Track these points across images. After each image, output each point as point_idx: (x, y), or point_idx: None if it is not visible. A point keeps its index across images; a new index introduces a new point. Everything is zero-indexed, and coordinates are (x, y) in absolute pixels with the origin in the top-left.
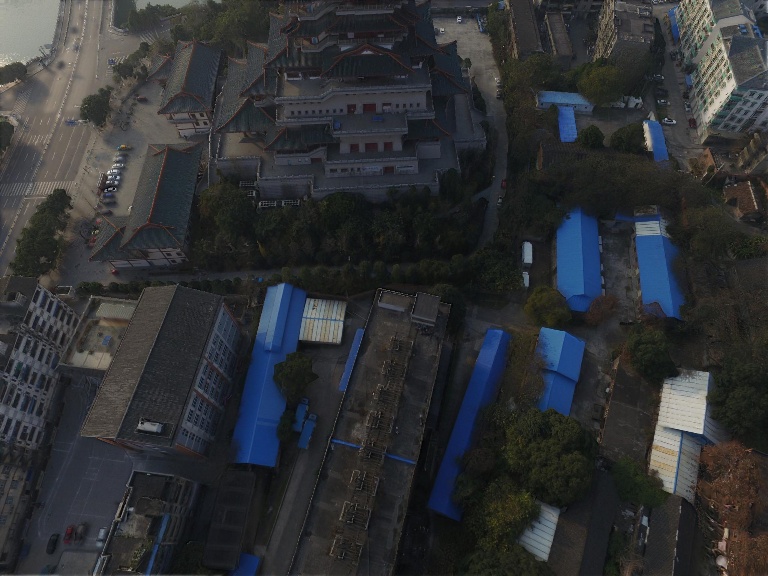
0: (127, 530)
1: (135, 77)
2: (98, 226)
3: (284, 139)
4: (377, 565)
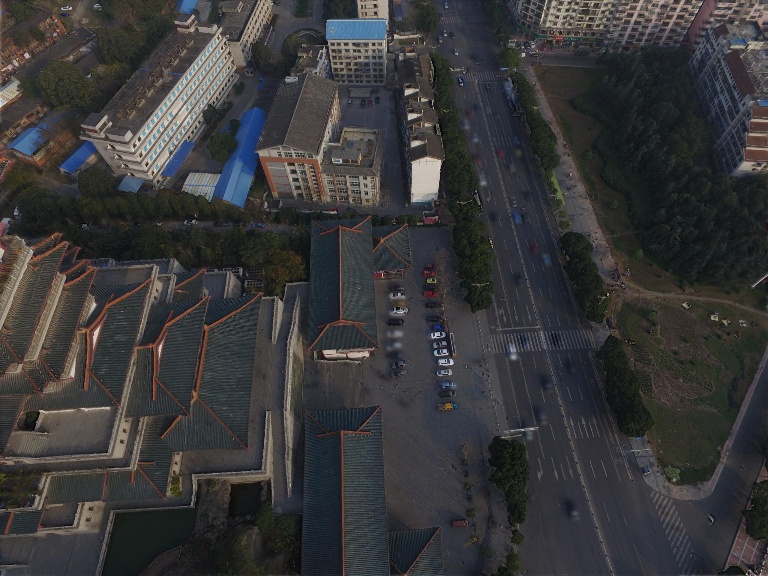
0: (311, 69)
1: (484, 575)
2: (432, 286)
3: (178, 282)
4: (173, 41)
